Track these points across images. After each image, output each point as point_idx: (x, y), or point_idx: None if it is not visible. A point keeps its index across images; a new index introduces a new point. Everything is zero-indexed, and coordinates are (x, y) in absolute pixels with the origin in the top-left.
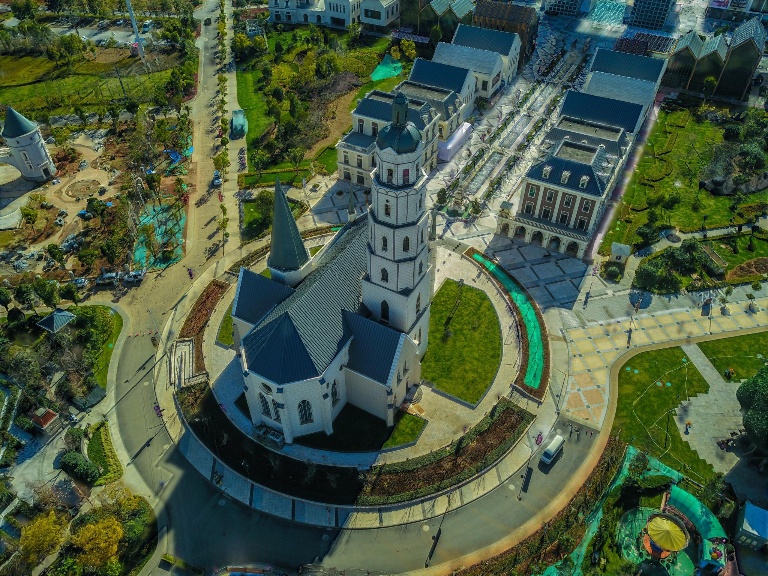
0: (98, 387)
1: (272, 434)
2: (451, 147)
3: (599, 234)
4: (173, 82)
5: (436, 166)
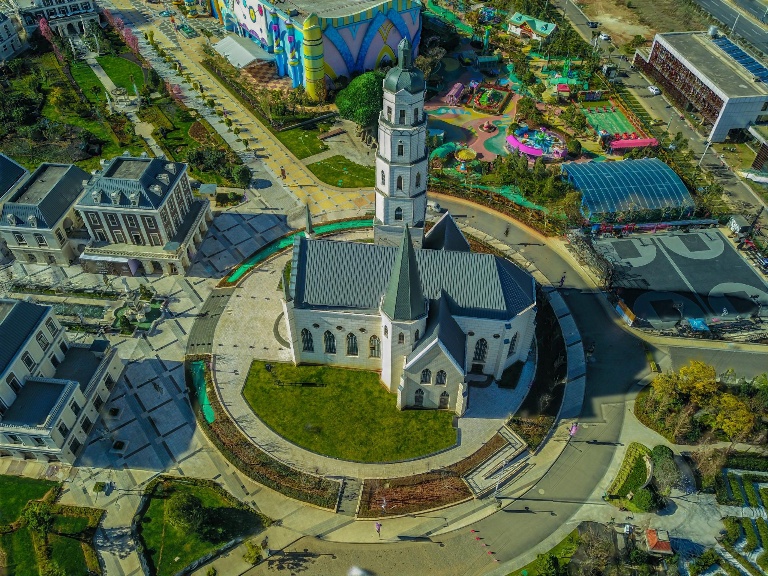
0: None
1: None
2: None
3: None
4: None
5: None
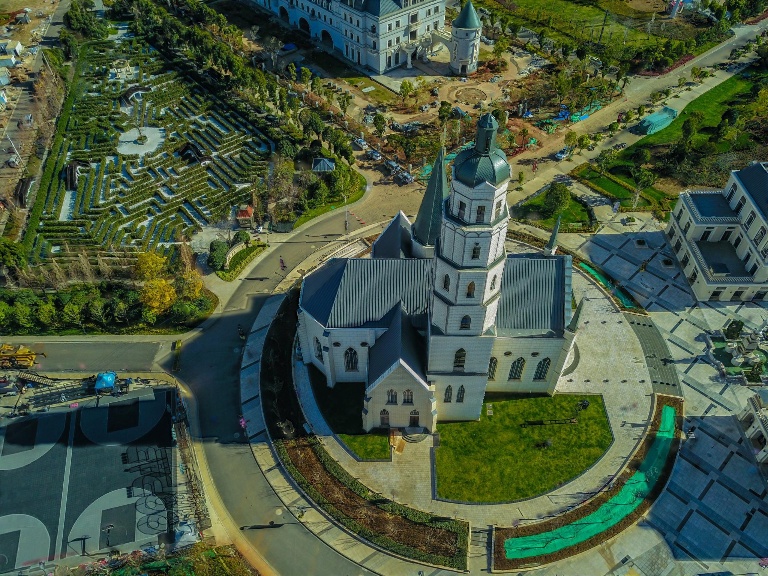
0: (291, 224)
1: (299, 344)
2: None
3: None
4: (650, 51)
5: None
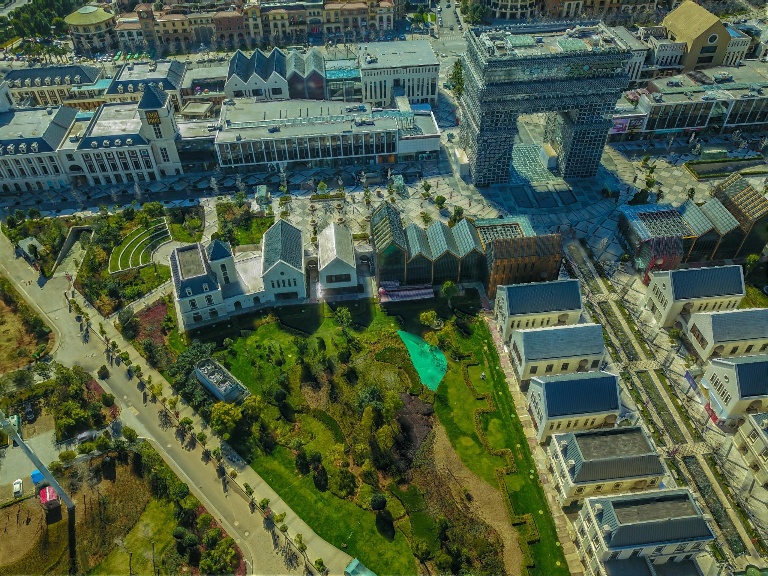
0: None
1: None
2: None
3: None
4: None
5: None
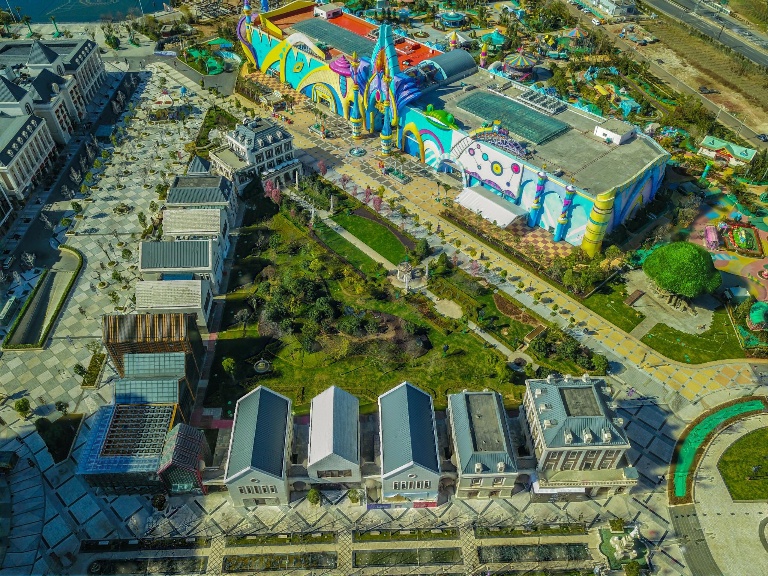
0: None
1: None
2: None
3: None
4: None
5: None
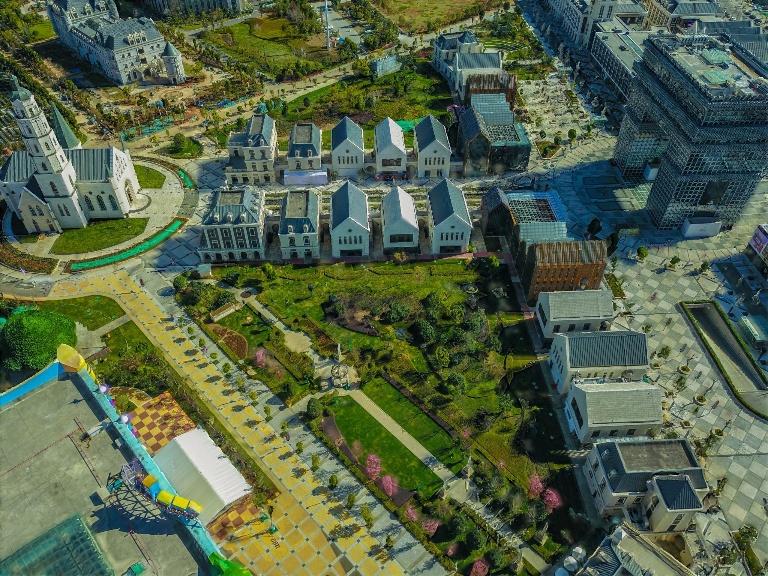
0: None
1: None
2: (288, 177)
3: (234, 263)
4: None
5: (274, 182)
